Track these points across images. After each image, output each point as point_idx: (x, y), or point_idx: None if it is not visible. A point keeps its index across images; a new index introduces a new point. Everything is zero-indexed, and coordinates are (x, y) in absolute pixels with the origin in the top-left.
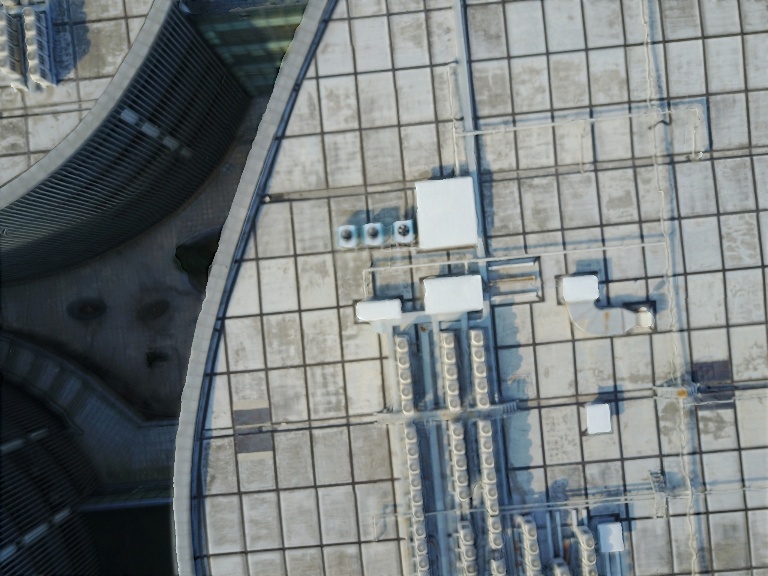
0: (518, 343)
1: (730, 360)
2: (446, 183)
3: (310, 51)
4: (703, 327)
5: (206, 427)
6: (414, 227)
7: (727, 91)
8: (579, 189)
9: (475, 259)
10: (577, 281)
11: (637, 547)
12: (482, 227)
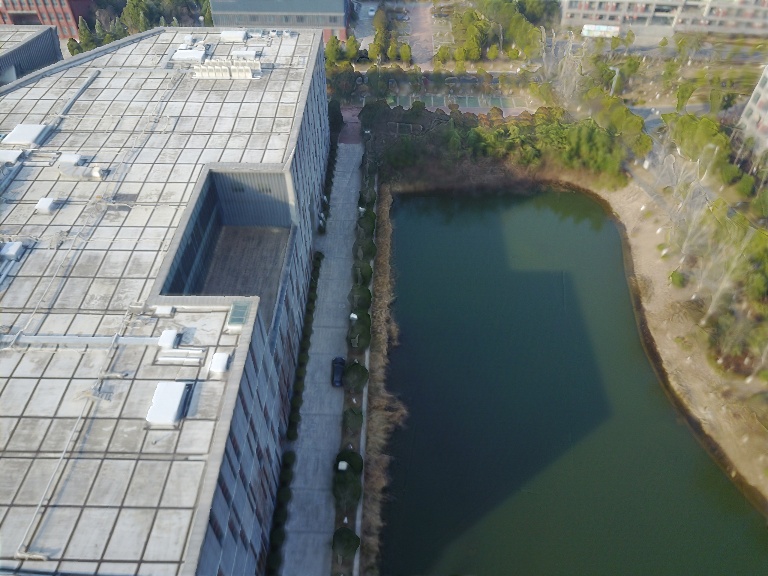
0: (26, 179)
1: (138, 194)
2: (32, 125)
3: (6, 92)
4: (131, 181)
5: None
6: (4, 136)
7: (190, 116)
8: None
9: (27, 149)
10: (70, 155)
11: (28, 262)
12: (41, 142)
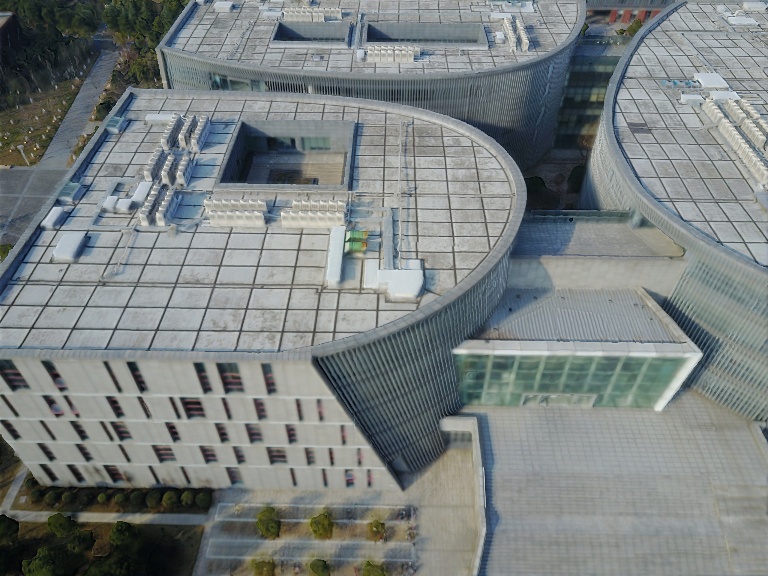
0: None
1: None
2: (708, 73)
3: (635, 50)
4: None
5: (615, 126)
6: None
7: None
8: (767, 83)
9: None
10: None
11: None
12: None
